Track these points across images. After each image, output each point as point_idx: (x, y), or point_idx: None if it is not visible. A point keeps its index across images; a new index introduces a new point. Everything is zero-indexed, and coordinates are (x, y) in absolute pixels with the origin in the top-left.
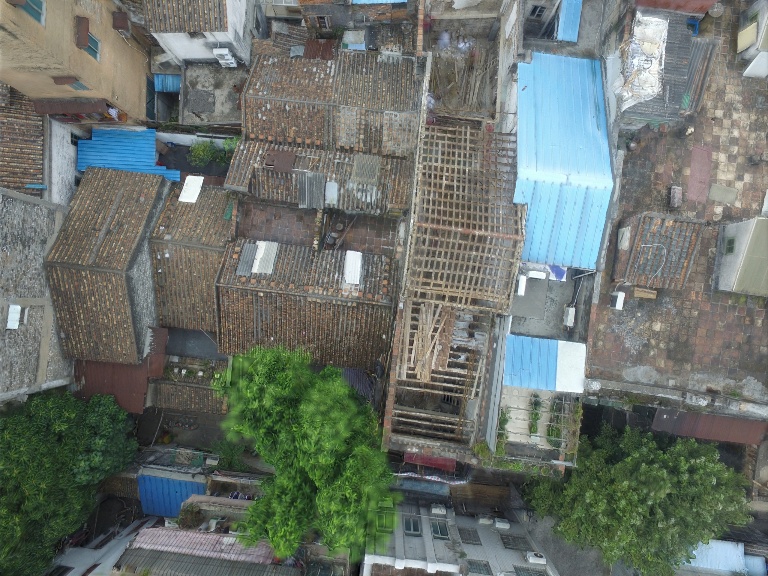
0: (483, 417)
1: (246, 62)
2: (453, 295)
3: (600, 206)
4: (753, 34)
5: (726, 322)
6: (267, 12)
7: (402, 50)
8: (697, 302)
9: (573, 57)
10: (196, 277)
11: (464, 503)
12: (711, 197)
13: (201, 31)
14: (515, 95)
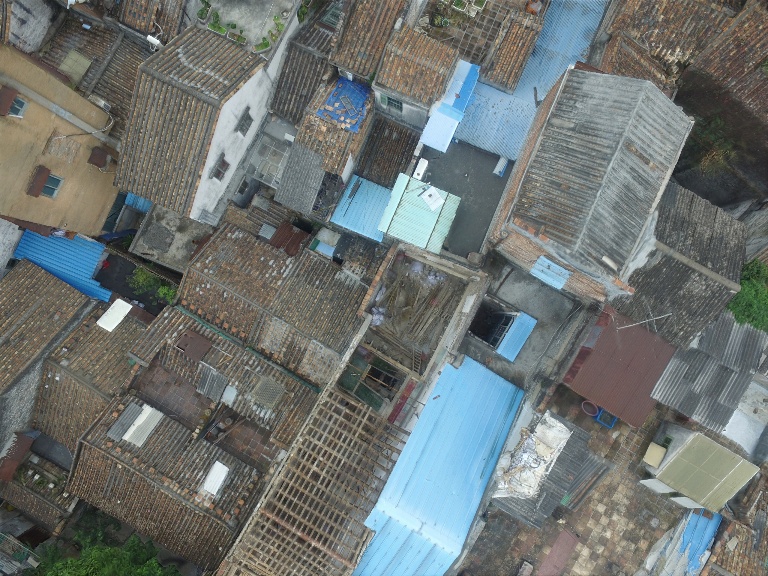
0: None
1: None
2: None
3: (441, 565)
4: (659, 458)
5: None
6: (264, 170)
7: (364, 274)
8: None
9: (502, 377)
10: (78, 407)
11: None
12: None
13: None
14: None
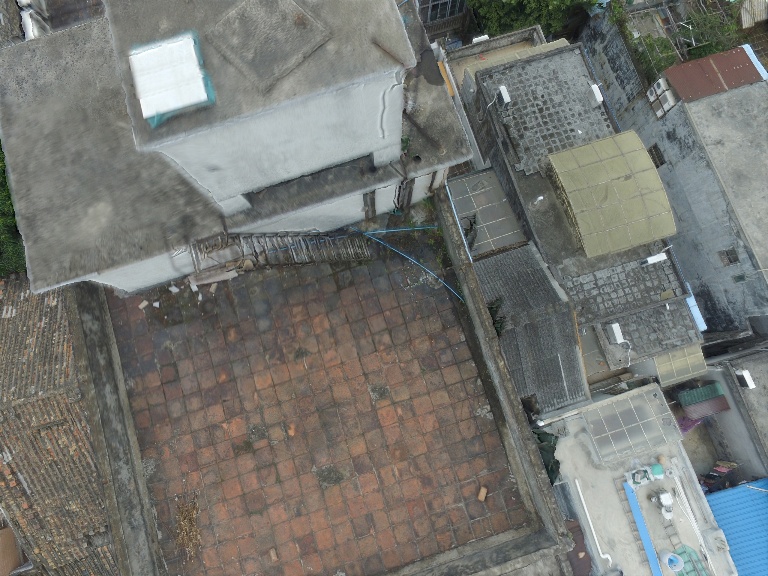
0: None
1: None
2: None
3: None
4: None
5: None
6: None
7: None
8: None
9: None
10: None
11: None
12: None
13: None
14: None
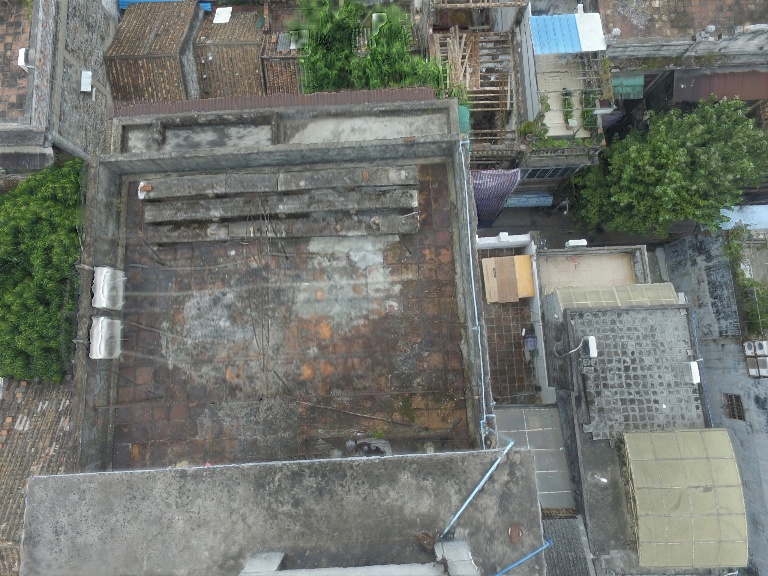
0: (522, 110)
1: None
2: None
3: None
4: None
5: None
6: None
7: None
8: None
9: None
10: (238, 77)
11: None
12: None
13: None
14: None
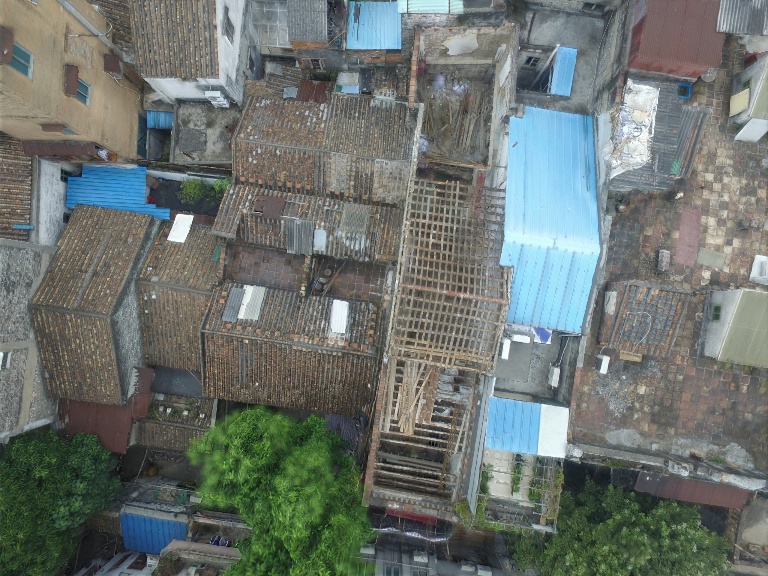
0: (465, 475)
1: (238, 103)
2: (437, 355)
3: (586, 271)
4: (745, 100)
5: (711, 387)
6: (262, 50)
7: (396, 94)
8: (682, 366)
9: (565, 112)
10: (183, 318)
11: (448, 544)
12: (699, 261)
13: (192, 77)
14: (507, 147)
